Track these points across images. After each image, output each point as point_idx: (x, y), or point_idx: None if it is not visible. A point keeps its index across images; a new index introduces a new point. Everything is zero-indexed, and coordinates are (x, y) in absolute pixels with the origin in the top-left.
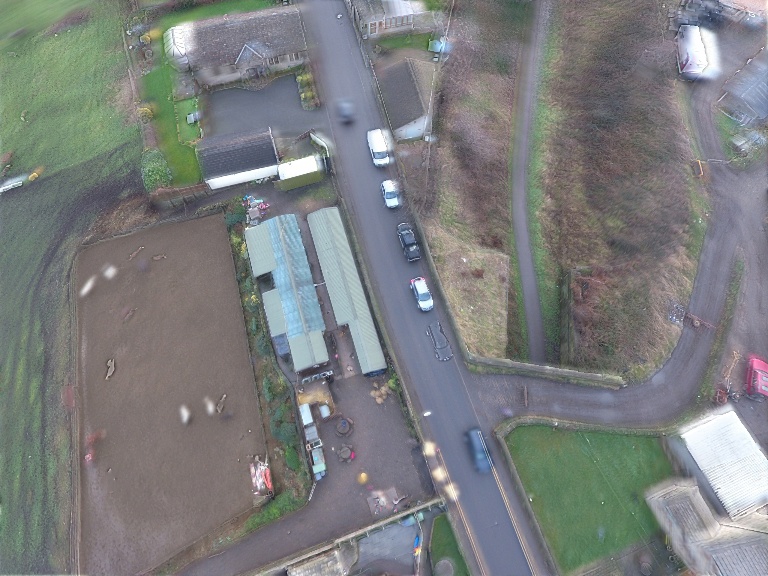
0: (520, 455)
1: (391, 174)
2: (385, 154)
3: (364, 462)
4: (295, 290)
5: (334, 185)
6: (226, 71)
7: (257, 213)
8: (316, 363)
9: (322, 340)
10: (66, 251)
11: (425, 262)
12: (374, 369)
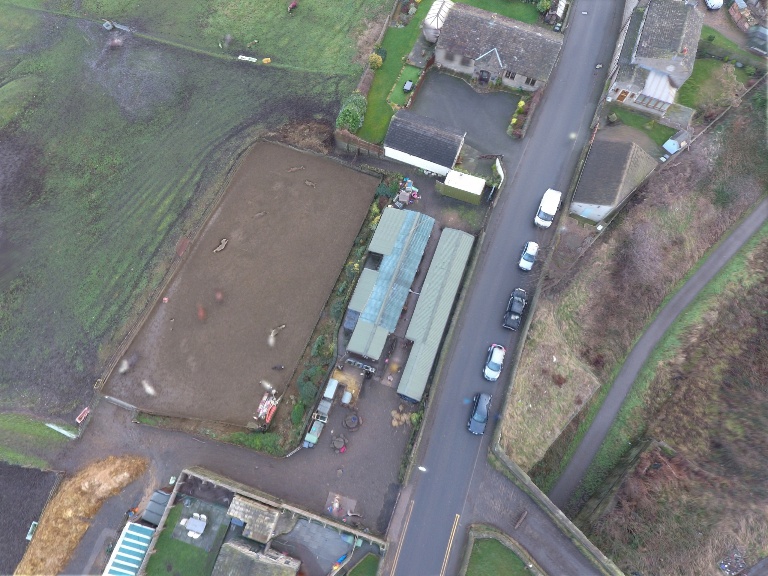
0: (479, 564)
1: (543, 239)
2: (550, 218)
3: (348, 462)
4: (391, 284)
5: (486, 216)
6: (464, 61)
7: (406, 198)
8: (366, 355)
9: (384, 340)
10: (251, 134)
11: (517, 336)
12: (408, 395)
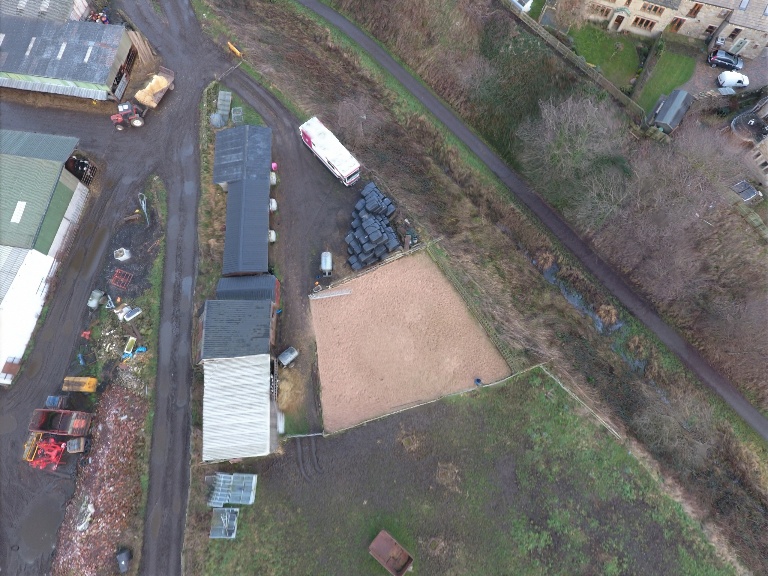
0: None
1: None
2: None
3: None
4: None
5: None
6: None
7: None
8: None
9: None
10: None
11: None
12: None
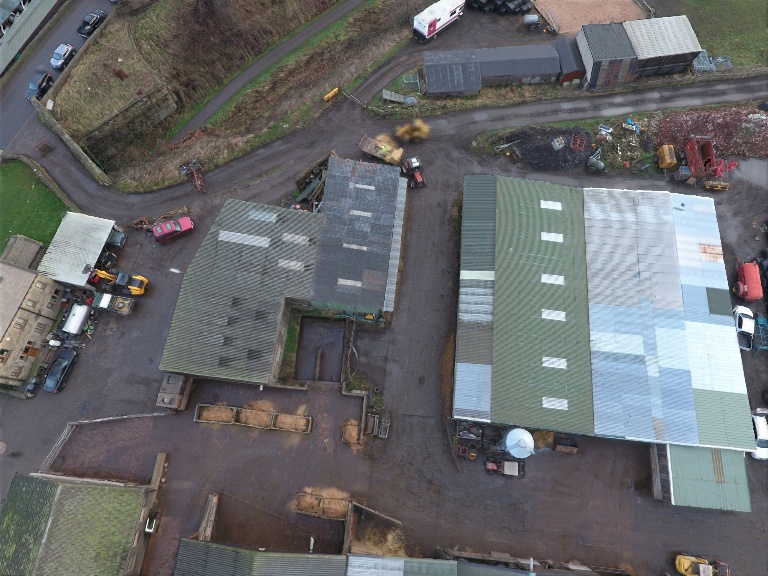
0: (3, 176)
1: None
2: None
3: None
4: None
5: None
6: None
7: None
8: None
9: None
10: None
11: None
12: None
